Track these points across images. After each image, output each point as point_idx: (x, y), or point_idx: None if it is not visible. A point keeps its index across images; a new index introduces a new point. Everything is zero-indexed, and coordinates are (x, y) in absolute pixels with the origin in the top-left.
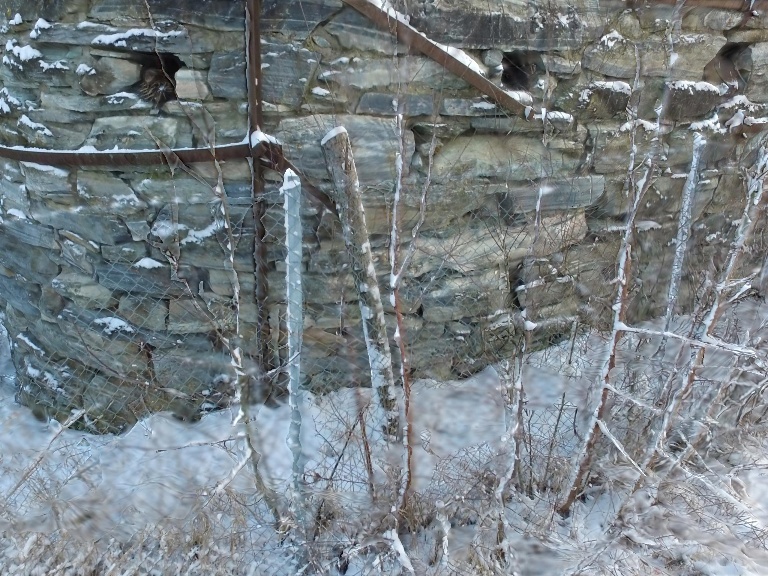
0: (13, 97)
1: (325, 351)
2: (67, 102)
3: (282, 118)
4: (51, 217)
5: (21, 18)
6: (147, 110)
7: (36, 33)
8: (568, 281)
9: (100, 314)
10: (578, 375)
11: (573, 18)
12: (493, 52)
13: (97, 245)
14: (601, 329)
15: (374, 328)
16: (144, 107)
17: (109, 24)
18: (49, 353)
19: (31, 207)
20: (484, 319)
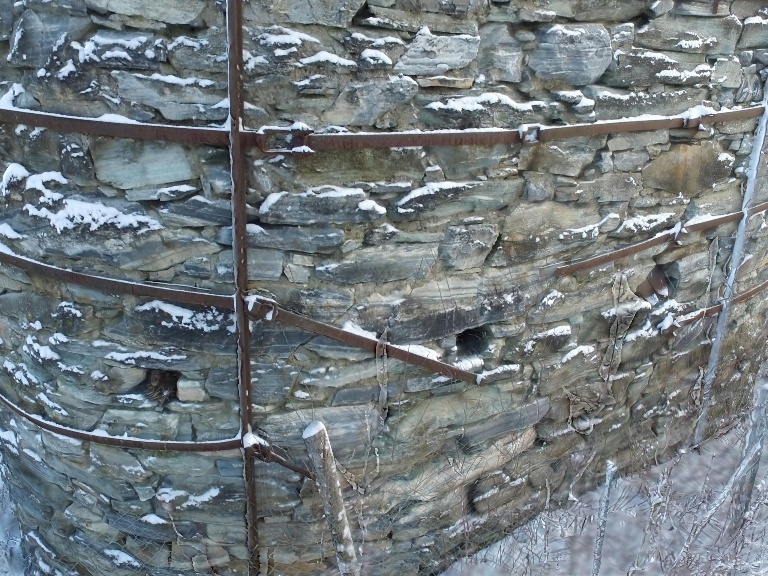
0: (32, 375)
1: None
2: (82, 395)
3: (269, 415)
4: (65, 469)
5: (41, 325)
6: (153, 408)
7: (55, 341)
8: (520, 483)
9: (109, 546)
10: (528, 575)
11: (517, 295)
12: (448, 339)
13: (107, 499)
14: (551, 509)
15: None
16: (150, 406)
17: (120, 343)
18: (59, 555)
19: (47, 457)
20: (446, 531)
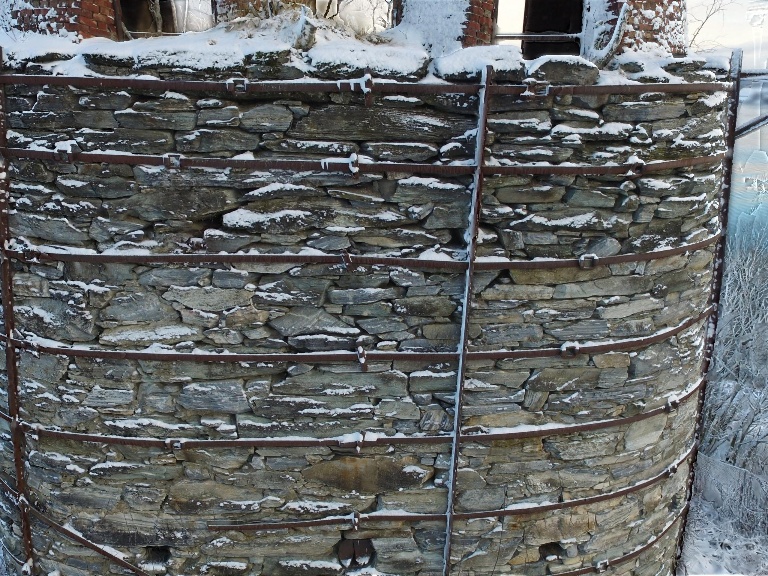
0: None
1: None
2: None
3: (41, 557)
4: None
5: None
6: None
7: None
8: None
9: None
10: None
11: (185, 534)
12: (133, 548)
13: None
14: None
15: None
16: (7, 530)
17: None
18: None
19: None
20: None
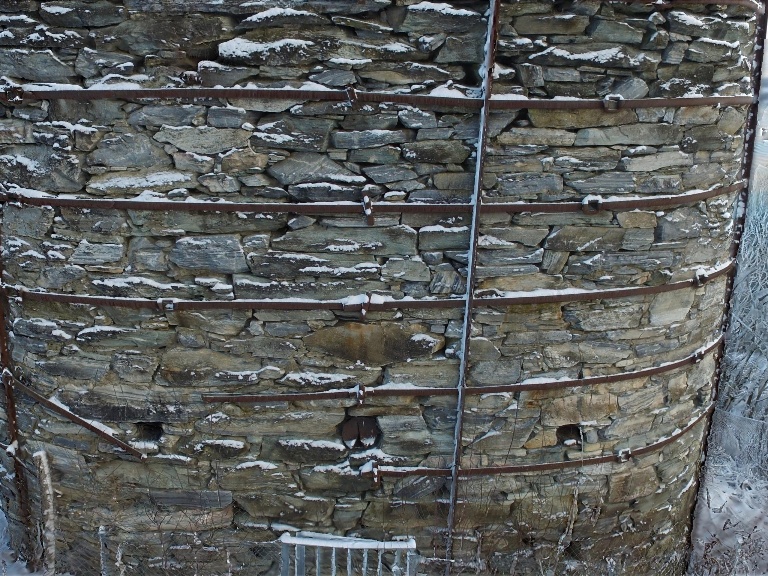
0: None
1: (59, 550)
2: None
3: (27, 438)
4: None
5: None
6: None
7: None
8: (213, 550)
9: None
10: None
11: (179, 407)
12: (123, 424)
13: None
14: None
15: (46, 554)
16: None
17: None
18: None
19: None
20: (146, 560)
